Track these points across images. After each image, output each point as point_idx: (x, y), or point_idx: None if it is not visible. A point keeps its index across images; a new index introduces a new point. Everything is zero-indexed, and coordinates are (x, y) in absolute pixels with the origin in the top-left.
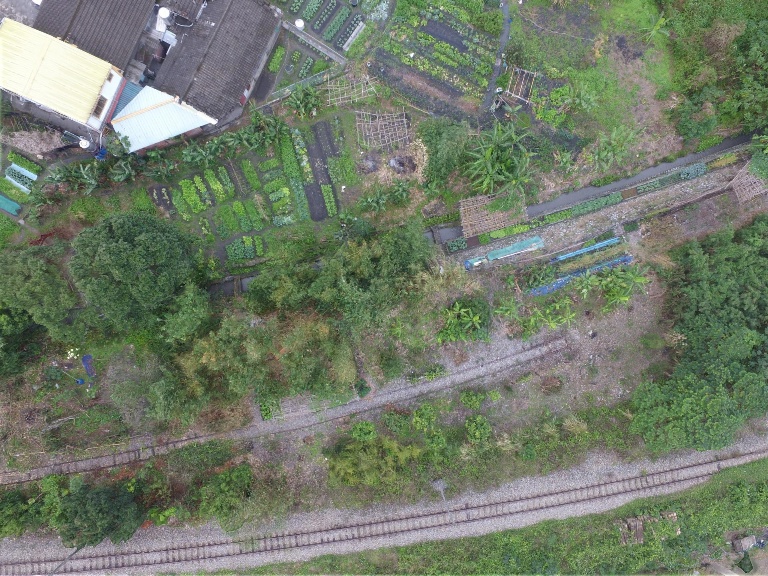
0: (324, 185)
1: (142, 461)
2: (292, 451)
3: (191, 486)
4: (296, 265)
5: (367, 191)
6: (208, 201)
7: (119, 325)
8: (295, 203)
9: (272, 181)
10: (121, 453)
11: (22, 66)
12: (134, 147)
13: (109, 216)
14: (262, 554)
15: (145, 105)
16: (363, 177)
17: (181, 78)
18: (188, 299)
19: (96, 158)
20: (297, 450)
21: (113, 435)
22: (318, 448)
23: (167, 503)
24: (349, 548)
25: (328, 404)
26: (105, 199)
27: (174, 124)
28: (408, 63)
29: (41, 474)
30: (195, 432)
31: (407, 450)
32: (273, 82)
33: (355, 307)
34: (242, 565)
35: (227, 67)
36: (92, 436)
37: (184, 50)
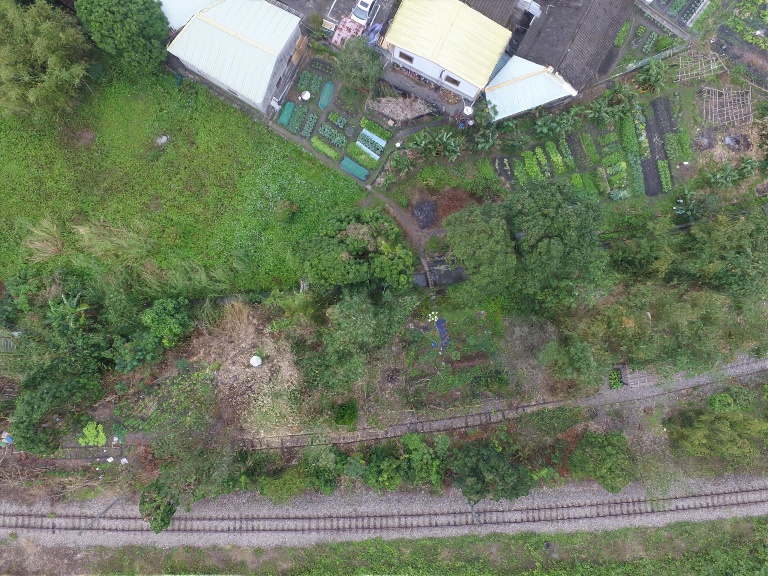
0: (661, 160)
1: (493, 423)
2: (633, 420)
3: (537, 450)
4: (671, 237)
5: (702, 168)
6: (547, 173)
7: (531, 288)
8: (631, 177)
9: (610, 155)
10: (473, 415)
11: (430, 31)
12: (499, 116)
13: (455, 184)
14: (619, 518)
15: (517, 74)
16: (698, 154)
17: (552, 49)
18: (603, 265)
19: (459, 126)
20: (638, 419)
21: (471, 397)
22: (657, 418)
23: (530, 464)
24: (703, 516)
25: (683, 375)
26: (451, 167)
27: (539, 94)
28: (751, 41)
29: (397, 432)
30: (543, 398)
31: (757, 423)
32: (616, 56)
33: (742, 280)
34: (599, 527)
35: (593, 39)
36: (444, 397)
37: (551, 21)
